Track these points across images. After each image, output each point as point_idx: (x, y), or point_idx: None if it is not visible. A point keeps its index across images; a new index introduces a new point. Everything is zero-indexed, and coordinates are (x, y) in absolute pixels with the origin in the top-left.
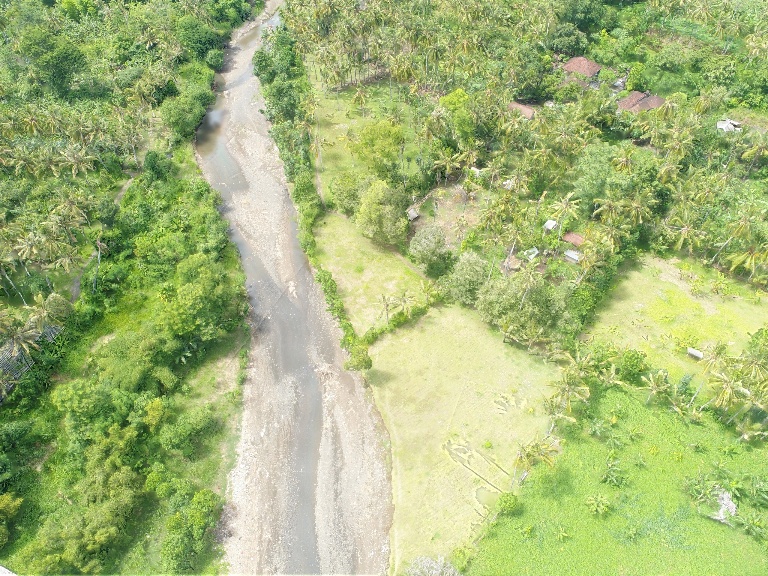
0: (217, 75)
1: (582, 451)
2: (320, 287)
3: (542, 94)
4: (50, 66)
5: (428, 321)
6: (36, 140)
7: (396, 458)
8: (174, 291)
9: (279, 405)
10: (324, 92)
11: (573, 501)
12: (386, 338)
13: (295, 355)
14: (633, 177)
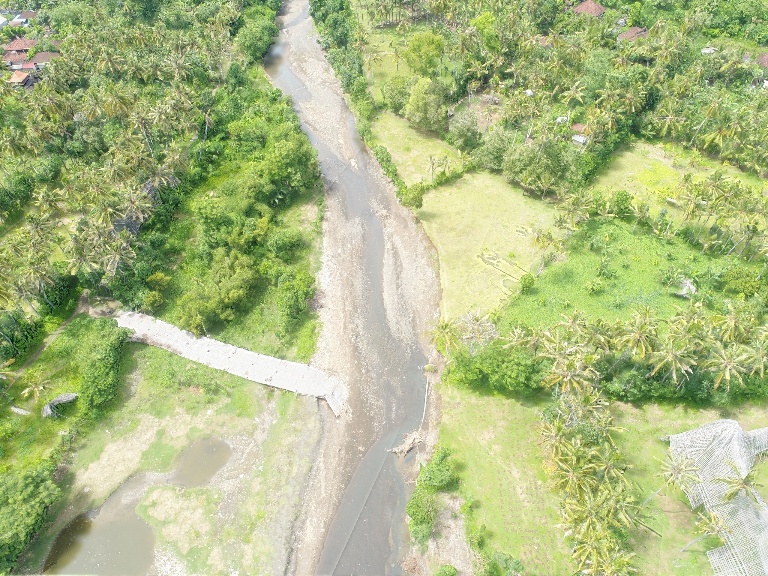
0: (276, 17)
1: (583, 259)
2: (376, 162)
3: None
4: (144, 0)
5: (464, 182)
6: None
7: (442, 262)
8: (263, 159)
9: (350, 234)
10: (369, 29)
11: (575, 287)
12: (431, 192)
13: (360, 205)
14: (627, 73)
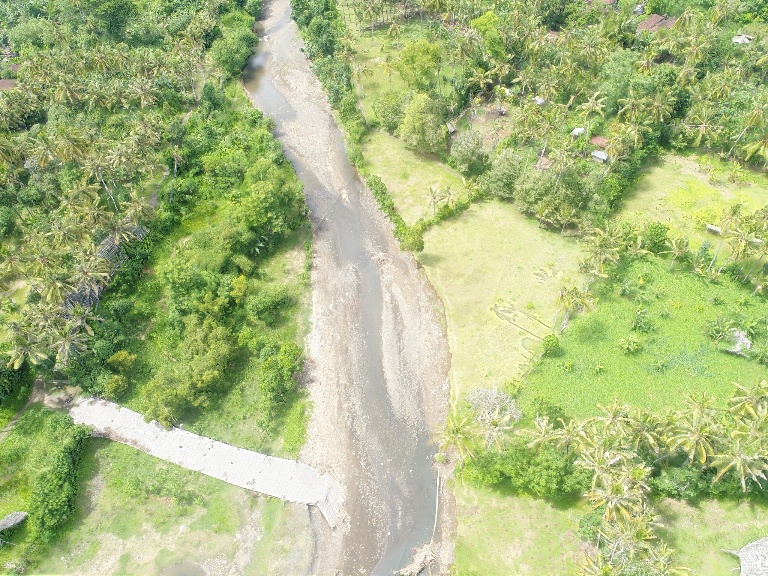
0: (256, 23)
1: (613, 308)
2: (370, 193)
3: (565, 21)
4: (108, 15)
5: (470, 214)
6: (100, 82)
7: (450, 319)
8: None
9: (343, 285)
10: (358, 31)
11: (607, 345)
12: (433, 229)
13: (353, 247)
14: (654, 78)
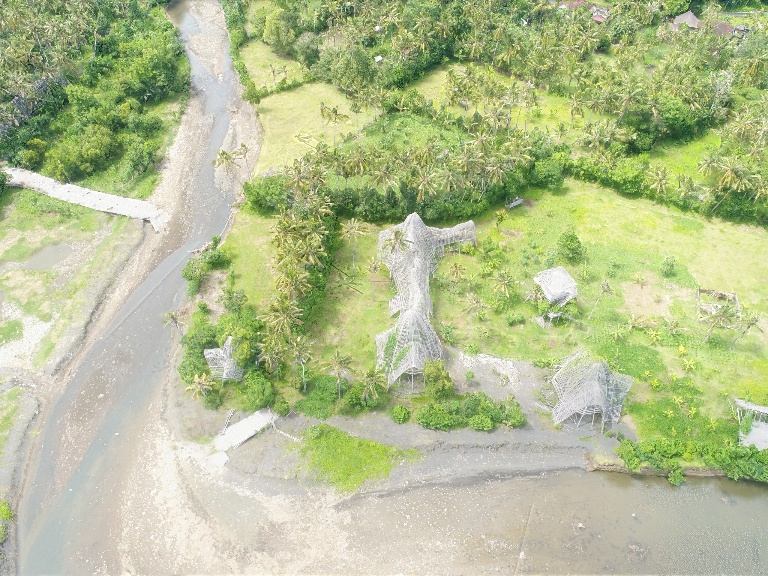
0: None
1: (376, 139)
2: (239, 77)
3: None
4: None
5: (302, 89)
6: None
7: (266, 140)
8: None
9: (203, 124)
10: None
11: None
12: (274, 95)
13: (217, 105)
14: (439, 6)
